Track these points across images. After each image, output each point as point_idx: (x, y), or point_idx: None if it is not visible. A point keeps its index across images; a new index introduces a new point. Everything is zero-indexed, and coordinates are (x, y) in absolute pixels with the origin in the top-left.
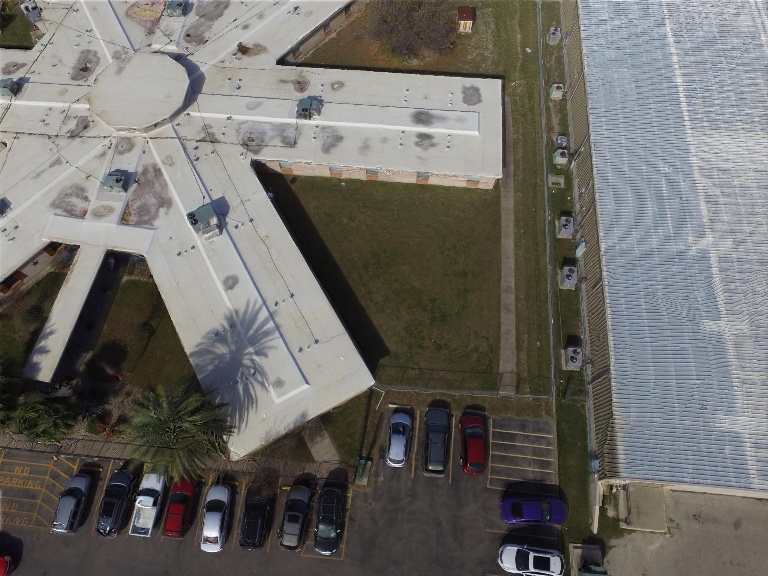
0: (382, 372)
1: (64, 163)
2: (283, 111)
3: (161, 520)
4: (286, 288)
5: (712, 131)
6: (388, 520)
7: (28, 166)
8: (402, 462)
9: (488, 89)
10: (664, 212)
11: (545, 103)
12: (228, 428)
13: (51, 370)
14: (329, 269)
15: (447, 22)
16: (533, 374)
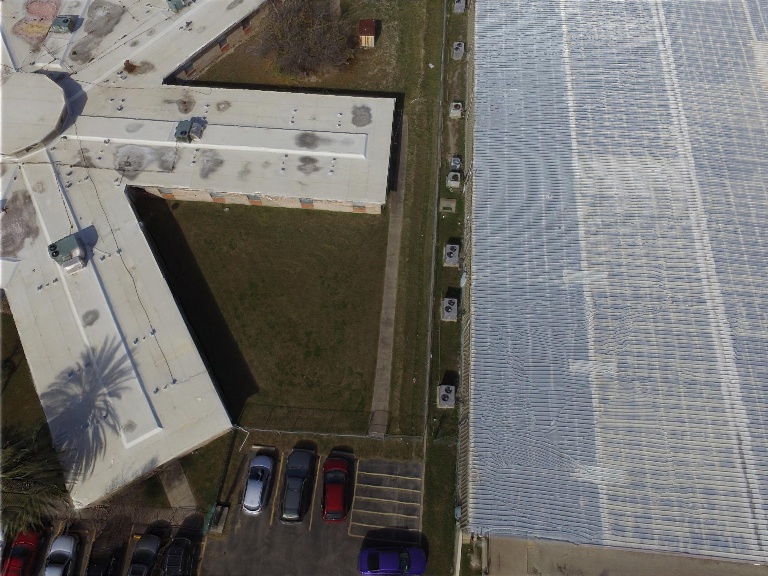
0: (249, 411)
1: None
2: (163, 134)
3: (2, 572)
4: (148, 324)
5: (599, 155)
6: (242, 570)
7: None
8: (258, 509)
9: (379, 109)
10: (541, 243)
11: (443, 122)
12: (72, 475)
13: None
14: (204, 301)
15: (343, 38)
16: (406, 412)
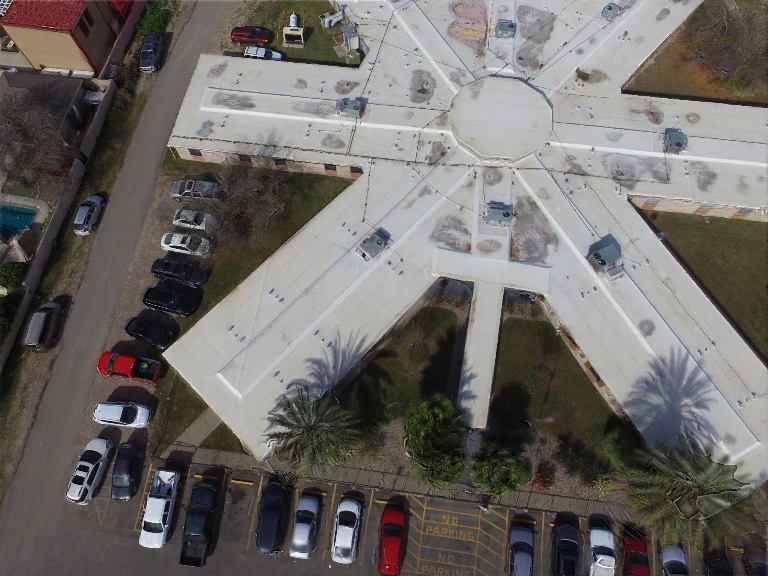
0: None
1: (434, 192)
2: (647, 144)
3: None
4: (705, 336)
5: None
6: None
7: (394, 194)
8: None
9: None
10: None
11: None
12: None
13: (483, 417)
14: None
15: None
16: None
